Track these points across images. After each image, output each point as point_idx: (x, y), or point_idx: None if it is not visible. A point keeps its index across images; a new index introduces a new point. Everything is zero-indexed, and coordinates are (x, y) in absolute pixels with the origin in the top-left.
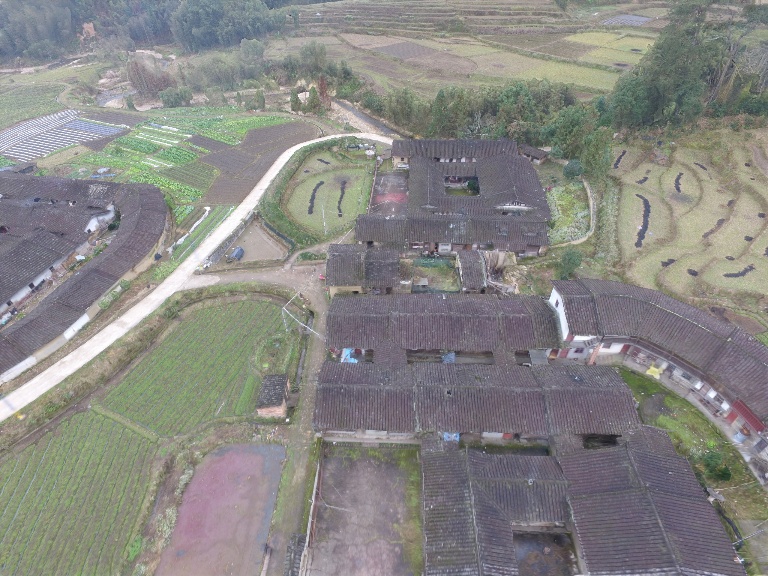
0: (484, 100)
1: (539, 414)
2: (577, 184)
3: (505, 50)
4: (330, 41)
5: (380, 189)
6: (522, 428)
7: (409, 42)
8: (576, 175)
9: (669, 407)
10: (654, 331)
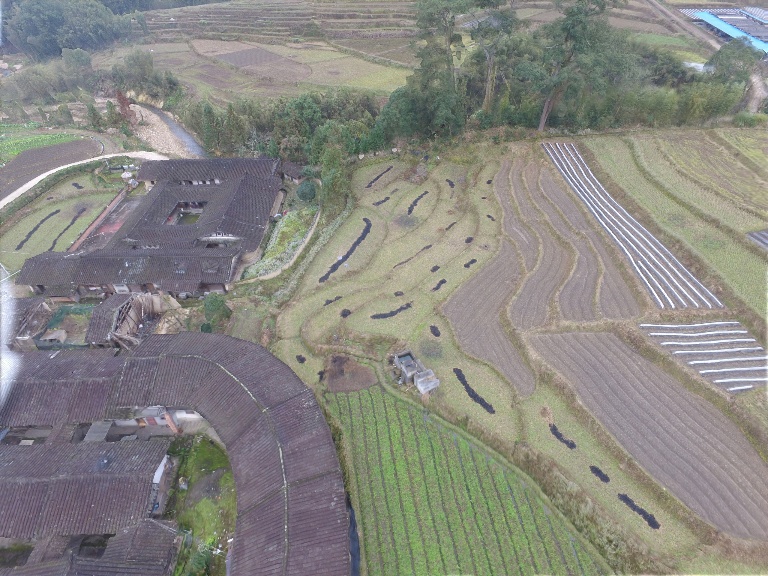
0: (273, 113)
1: (33, 511)
2: (312, 207)
3: (351, 55)
4: (178, 48)
5: (113, 217)
6: (5, 531)
7: (259, 48)
8: (308, 198)
9: (220, 487)
10: (204, 399)
